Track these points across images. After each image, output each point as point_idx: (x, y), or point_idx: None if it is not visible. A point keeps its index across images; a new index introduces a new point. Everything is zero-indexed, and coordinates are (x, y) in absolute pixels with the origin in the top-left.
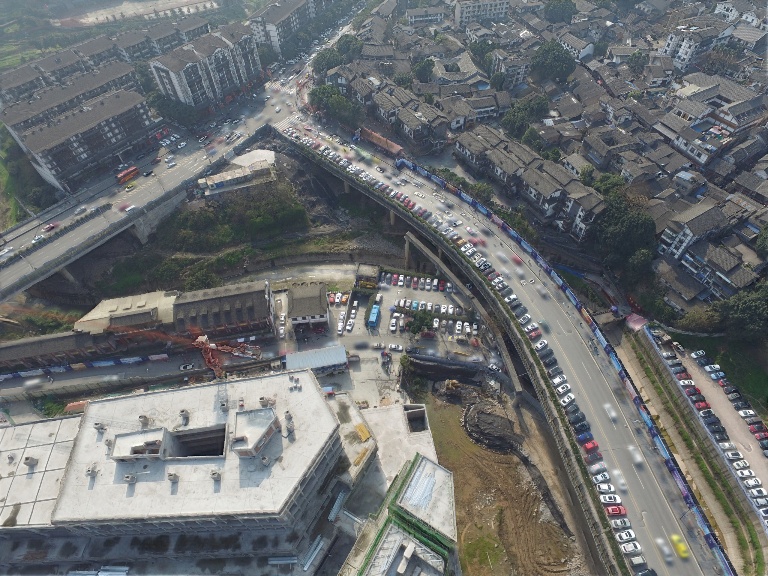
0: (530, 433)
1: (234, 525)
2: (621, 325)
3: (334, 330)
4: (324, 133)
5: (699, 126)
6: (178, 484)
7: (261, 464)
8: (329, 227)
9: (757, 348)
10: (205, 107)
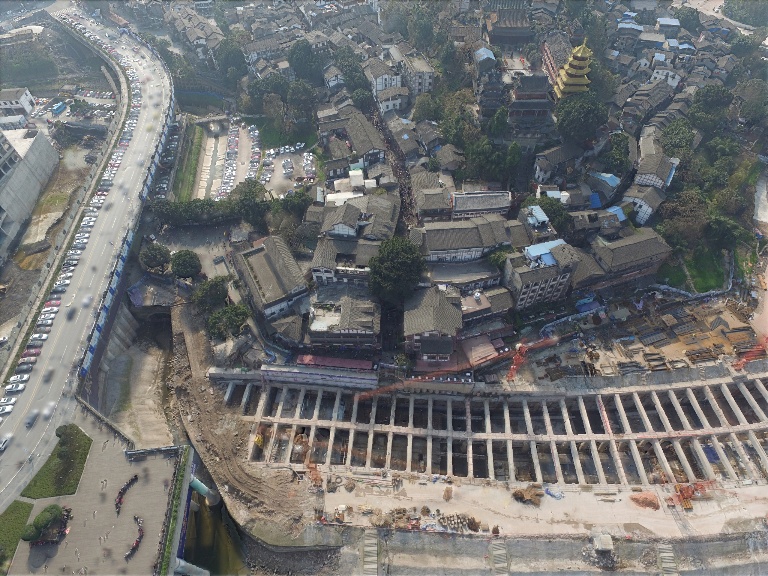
0: None
1: None
2: None
3: (30, 115)
4: (85, 17)
5: None
6: None
7: None
8: (72, 75)
9: None
10: None
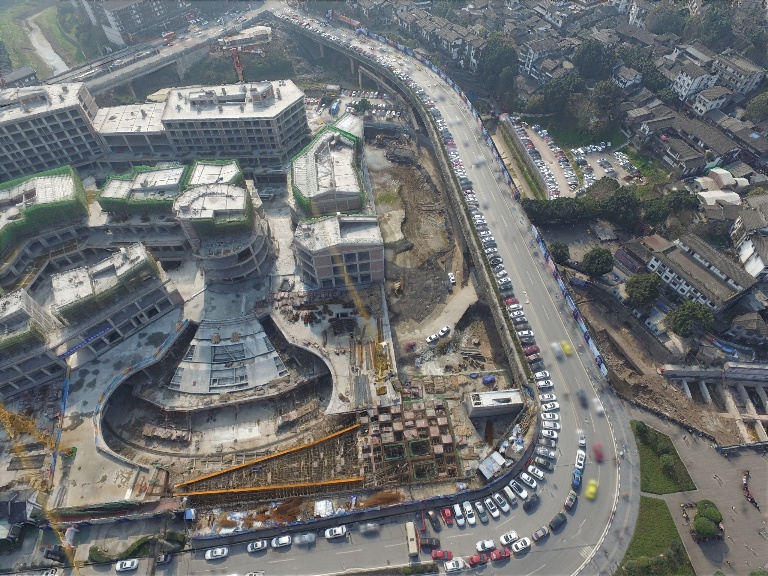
0: (424, 156)
1: (250, 136)
2: (496, 122)
3: None
4: (307, 18)
5: (563, 6)
6: (223, 111)
7: (264, 106)
8: (309, 75)
9: (564, 112)
10: (221, 1)
